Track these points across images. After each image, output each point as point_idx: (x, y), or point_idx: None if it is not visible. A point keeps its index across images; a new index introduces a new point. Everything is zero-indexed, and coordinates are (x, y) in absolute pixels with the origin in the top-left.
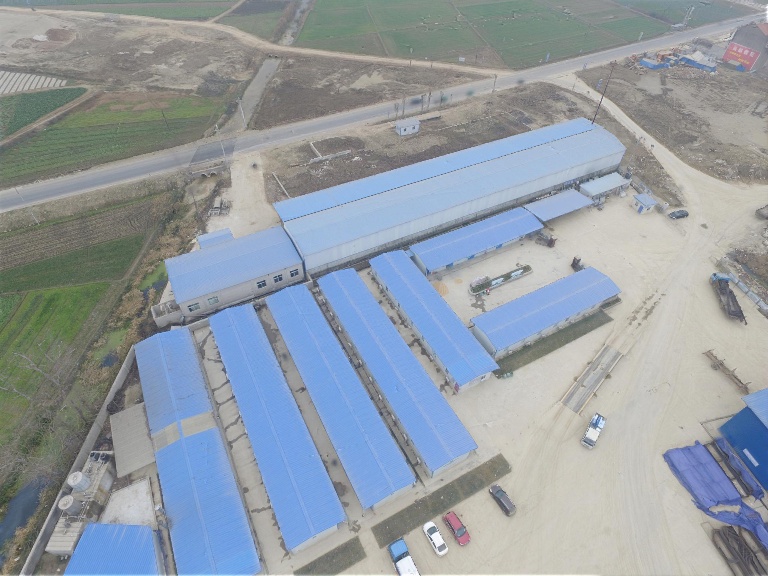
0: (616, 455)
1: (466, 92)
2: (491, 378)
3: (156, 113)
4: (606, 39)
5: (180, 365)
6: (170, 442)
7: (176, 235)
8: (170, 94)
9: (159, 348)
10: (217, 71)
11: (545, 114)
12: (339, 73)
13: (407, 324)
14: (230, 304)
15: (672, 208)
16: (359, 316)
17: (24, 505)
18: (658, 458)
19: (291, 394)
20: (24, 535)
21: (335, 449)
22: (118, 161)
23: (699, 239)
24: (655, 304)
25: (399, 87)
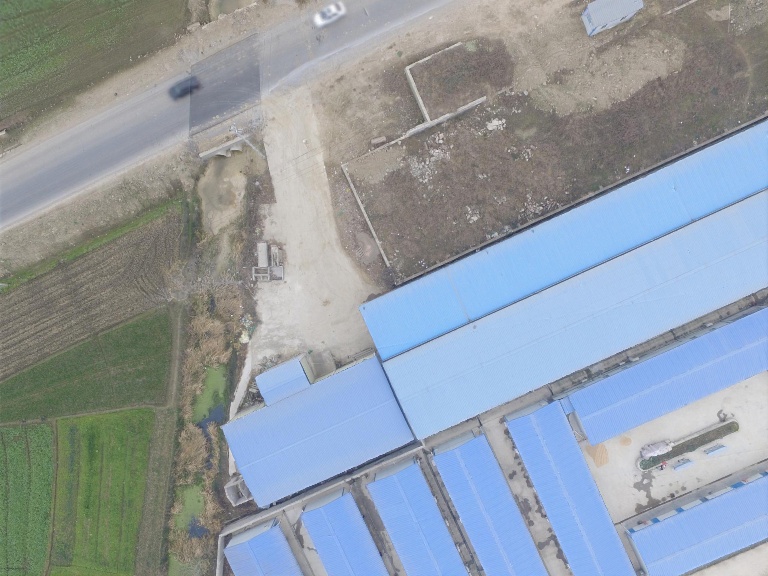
0: None
1: None
2: None
3: None
4: None
5: None
6: None
7: (214, 315)
8: None
9: (254, 564)
10: None
11: None
12: None
13: (545, 515)
14: None
15: None
16: (490, 529)
17: None
18: None
19: None
20: None
21: None
22: (60, 117)
23: None
24: None
25: None
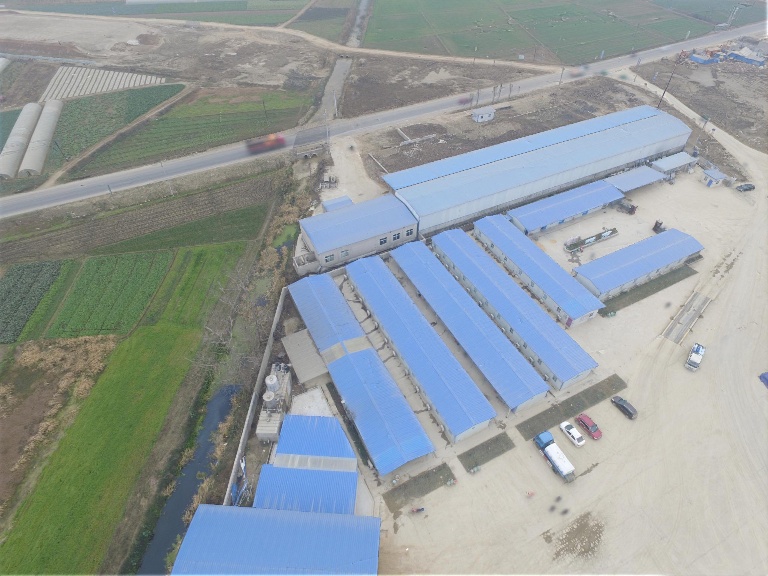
0: (717, 376)
1: (530, 85)
2: (597, 317)
3: (251, 105)
4: (653, 38)
5: (331, 301)
6: (338, 357)
7: (294, 204)
8: (259, 89)
9: (310, 288)
10: (297, 69)
11: (607, 104)
12: (409, 70)
13: (515, 274)
14: (356, 258)
15: (738, 183)
16: (476, 265)
17: (219, 407)
18: (755, 379)
19: (430, 324)
20: (227, 427)
21: (477, 365)
22: (230, 144)
23: (767, 208)
24: (734, 260)
25: (467, 82)
